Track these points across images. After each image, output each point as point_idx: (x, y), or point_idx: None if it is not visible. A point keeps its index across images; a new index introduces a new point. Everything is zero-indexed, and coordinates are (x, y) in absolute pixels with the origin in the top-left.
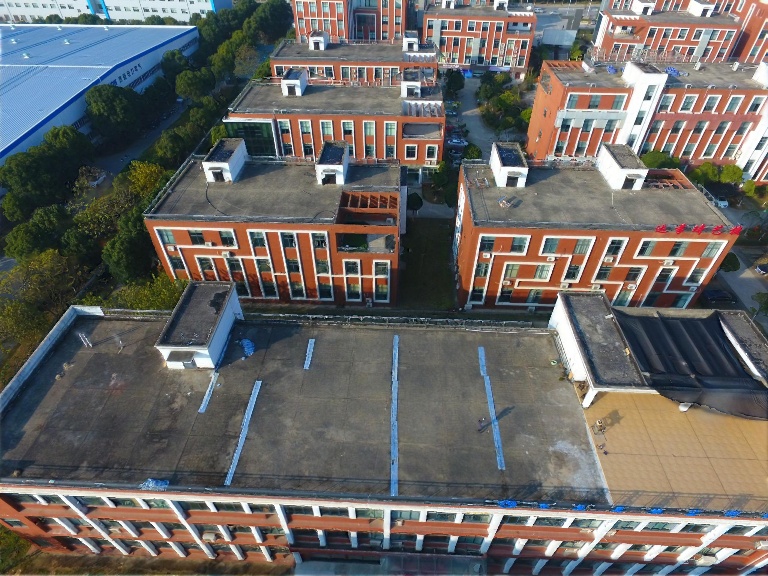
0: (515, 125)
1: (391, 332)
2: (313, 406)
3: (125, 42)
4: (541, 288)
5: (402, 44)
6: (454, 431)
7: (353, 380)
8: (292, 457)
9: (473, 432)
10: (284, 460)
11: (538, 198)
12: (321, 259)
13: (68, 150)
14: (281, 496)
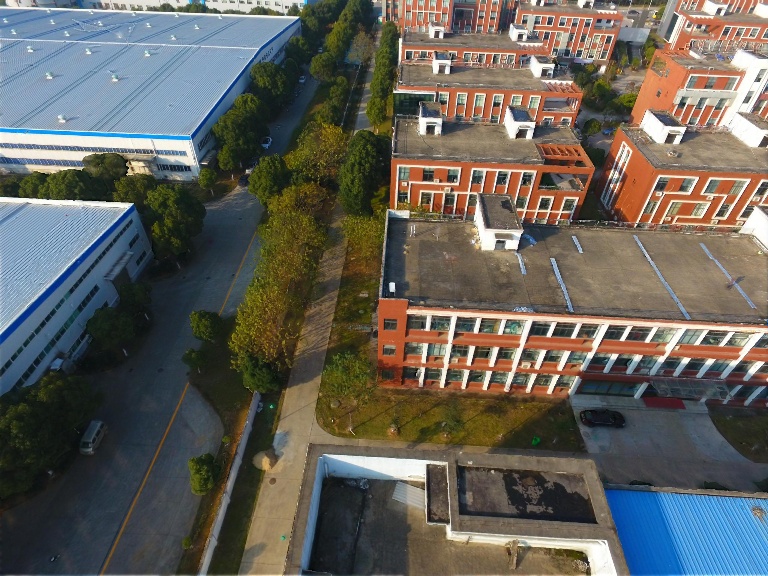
0: (617, 107)
1: (629, 233)
2: (602, 273)
3: (247, 29)
4: (694, 224)
5: (509, 35)
6: (710, 288)
7: (620, 259)
8: (606, 299)
9: (724, 289)
10: (602, 300)
11: (694, 152)
12: (522, 196)
13: (257, 114)
14: (615, 317)
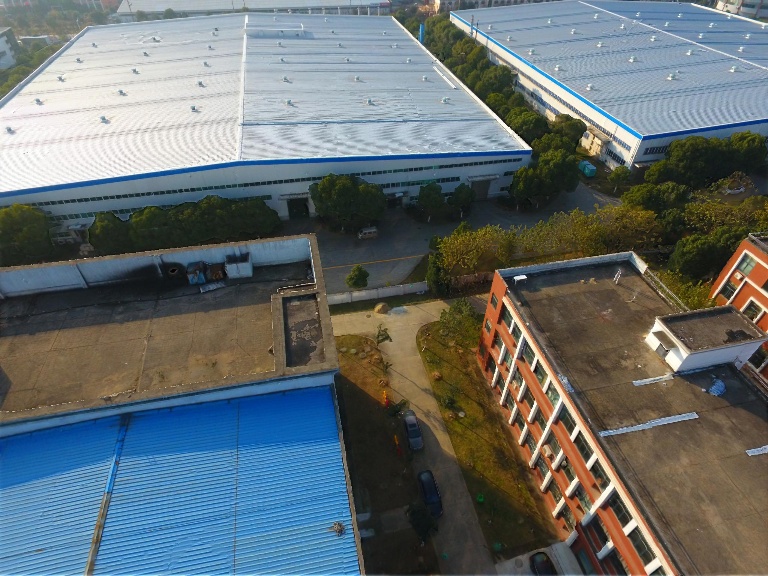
0: None
1: None
2: (719, 478)
3: None
4: None
5: None
6: None
7: None
8: (659, 479)
9: None
10: (651, 473)
11: None
12: None
13: (739, 154)
14: (623, 484)
